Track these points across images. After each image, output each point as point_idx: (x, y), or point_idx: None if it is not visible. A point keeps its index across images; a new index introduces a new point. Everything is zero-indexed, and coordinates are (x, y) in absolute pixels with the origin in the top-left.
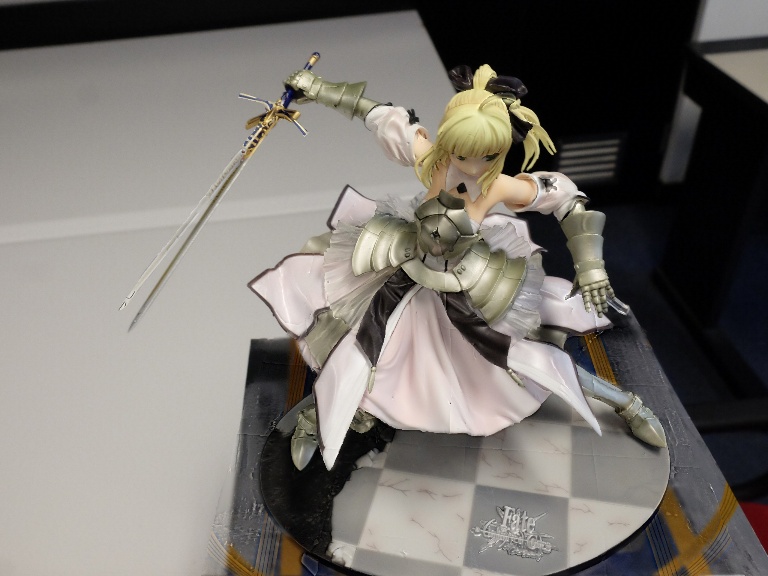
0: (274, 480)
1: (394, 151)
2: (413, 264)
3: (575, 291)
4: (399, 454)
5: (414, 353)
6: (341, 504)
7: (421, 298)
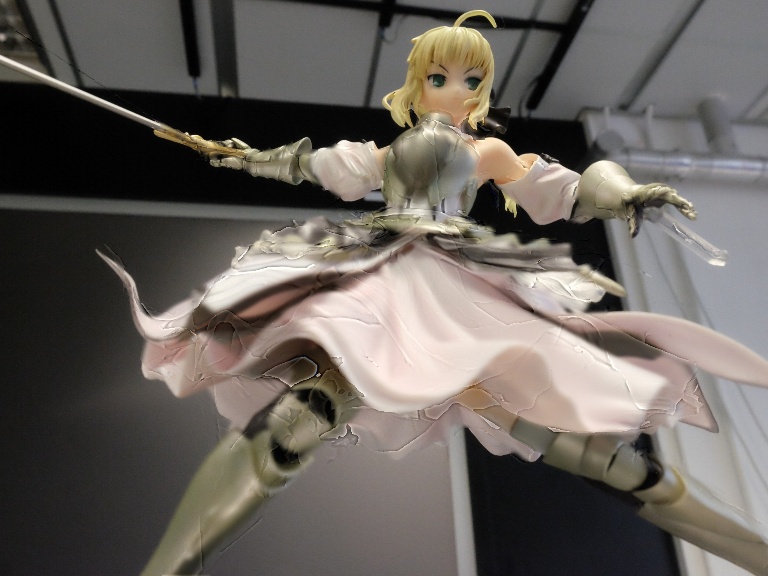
0: None
1: (341, 158)
2: (392, 212)
3: (639, 222)
4: None
5: (423, 301)
6: None
7: (413, 257)
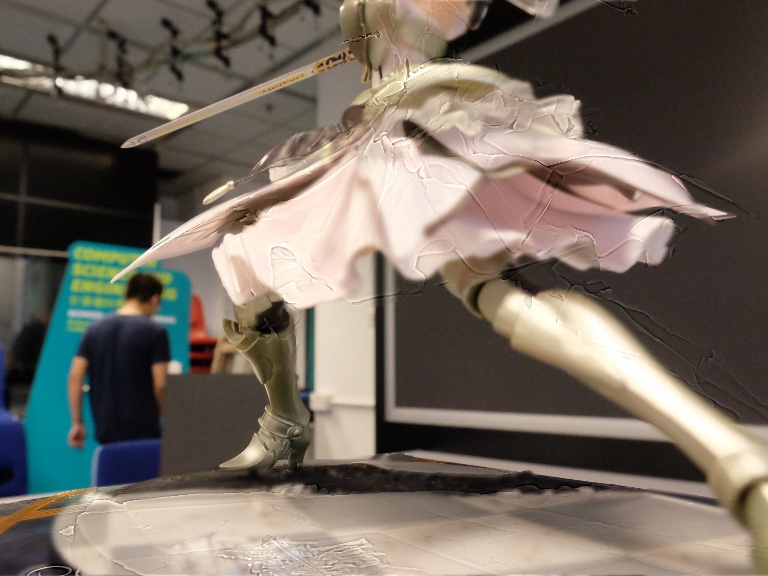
0: (191, 479)
1: None
2: None
3: (537, 4)
4: (343, 499)
5: None
6: (196, 495)
7: None
